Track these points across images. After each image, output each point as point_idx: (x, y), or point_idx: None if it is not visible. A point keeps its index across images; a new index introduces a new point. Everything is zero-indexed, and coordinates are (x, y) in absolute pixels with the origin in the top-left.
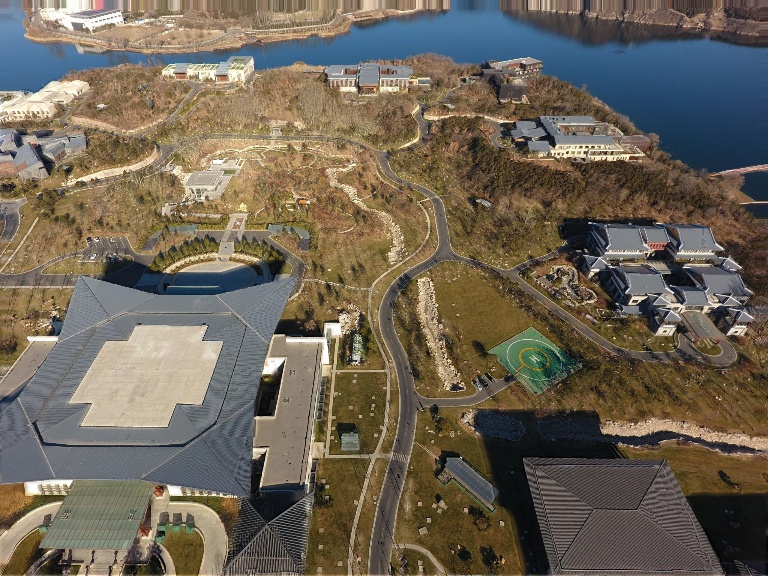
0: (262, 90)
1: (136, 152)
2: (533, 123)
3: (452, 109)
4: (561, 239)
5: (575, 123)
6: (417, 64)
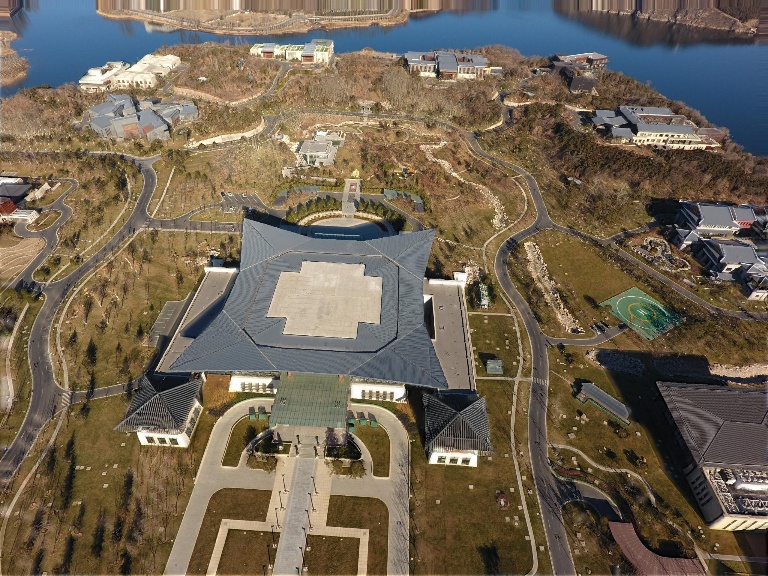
0: (346, 71)
1: (249, 120)
2: (612, 112)
3: (531, 96)
4: (649, 216)
5: (653, 114)
6: (486, 55)
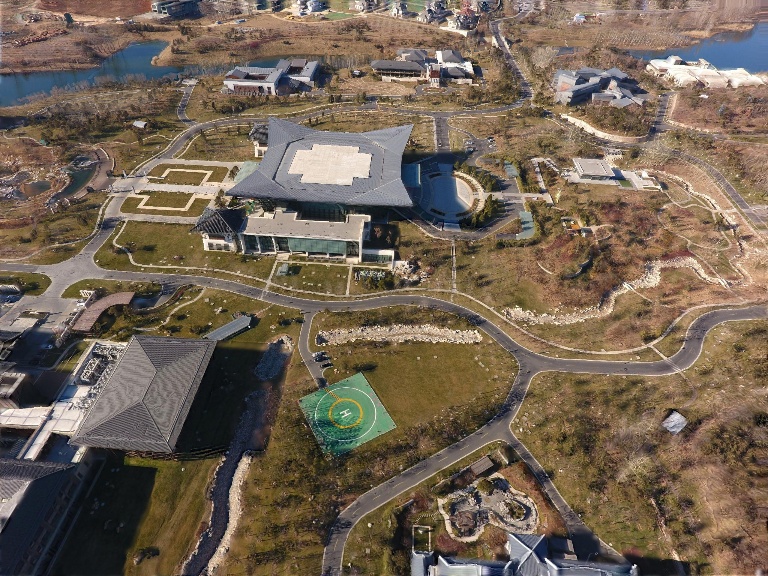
0: None
1: (617, 125)
2: None
3: None
4: (621, 545)
5: None
6: None
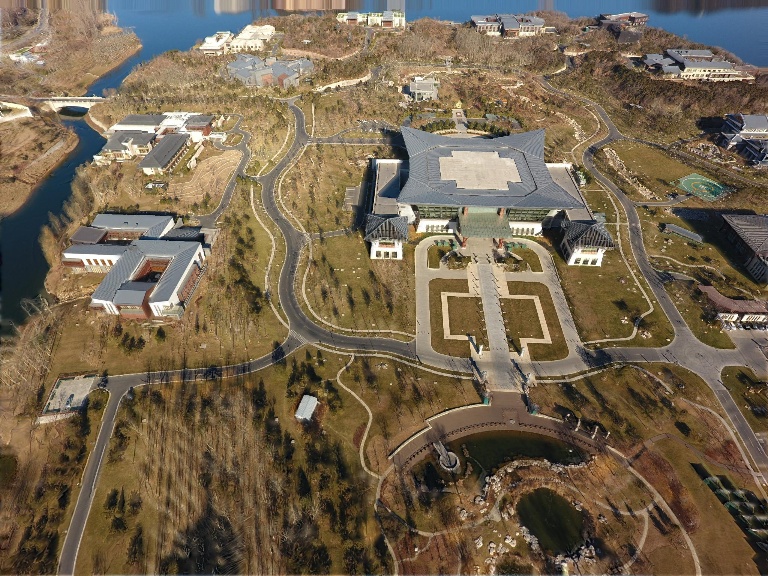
0: (422, 33)
1: (361, 69)
2: (660, 56)
3: (588, 47)
4: (699, 130)
5: (696, 55)
6: None
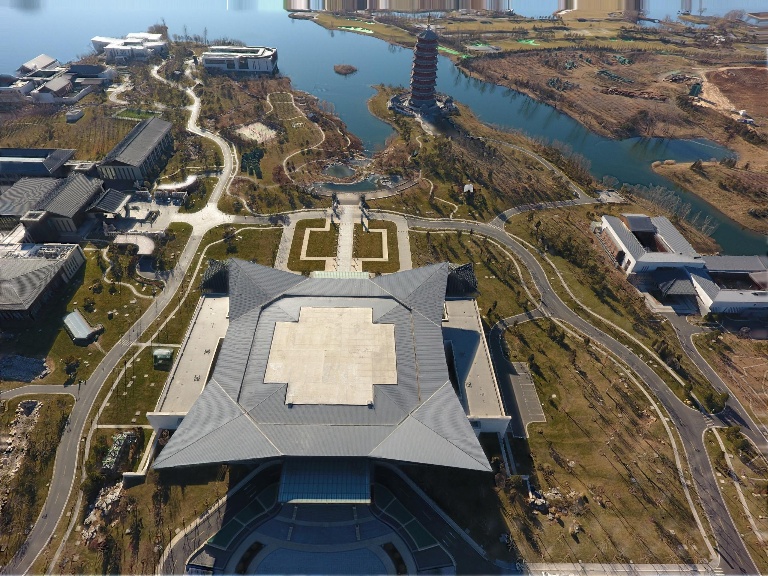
0: None
1: None
2: None
3: None
4: None
5: None
6: None
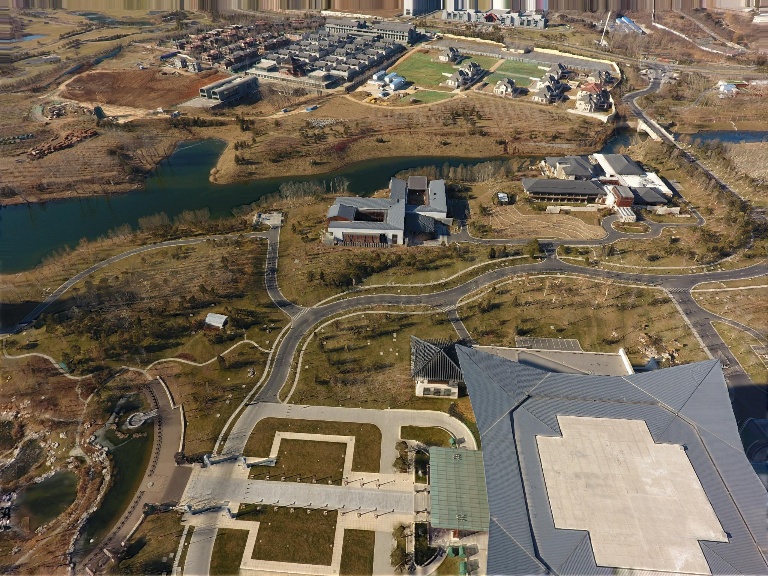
0: None
1: None
2: None
3: None
4: None
5: None
6: None
